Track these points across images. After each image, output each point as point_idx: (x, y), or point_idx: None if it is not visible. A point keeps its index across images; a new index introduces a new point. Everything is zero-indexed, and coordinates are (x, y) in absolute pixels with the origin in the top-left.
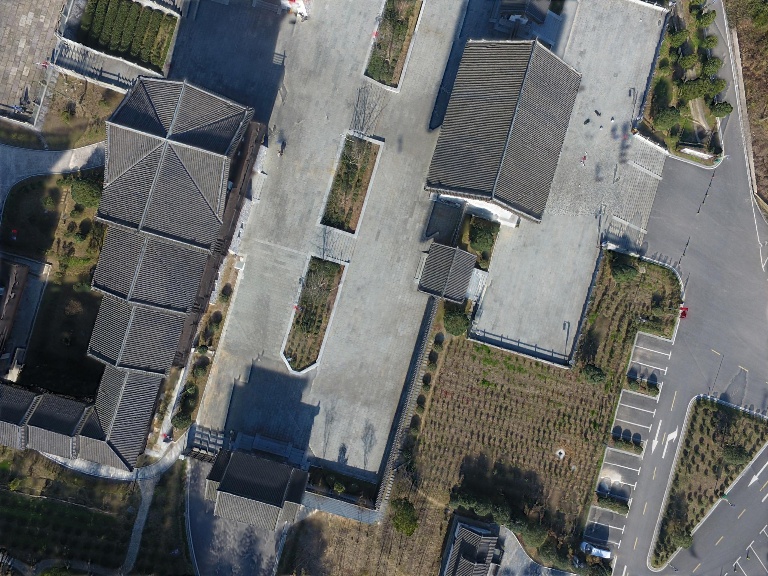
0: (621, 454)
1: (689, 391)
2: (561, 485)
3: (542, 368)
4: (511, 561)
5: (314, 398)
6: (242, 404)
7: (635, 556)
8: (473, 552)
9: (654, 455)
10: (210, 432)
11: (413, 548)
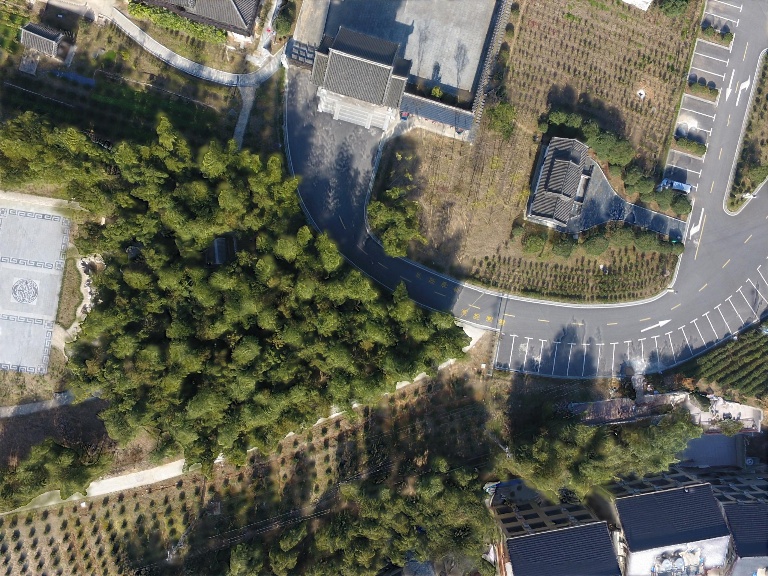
0: (697, 101)
1: (760, 43)
2: (642, 124)
3: (623, 7)
4: (596, 192)
5: (408, 18)
6: (338, 21)
7: (712, 199)
8: (566, 156)
9: (728, 103)
10: (307, 47)
11: (504, 170)
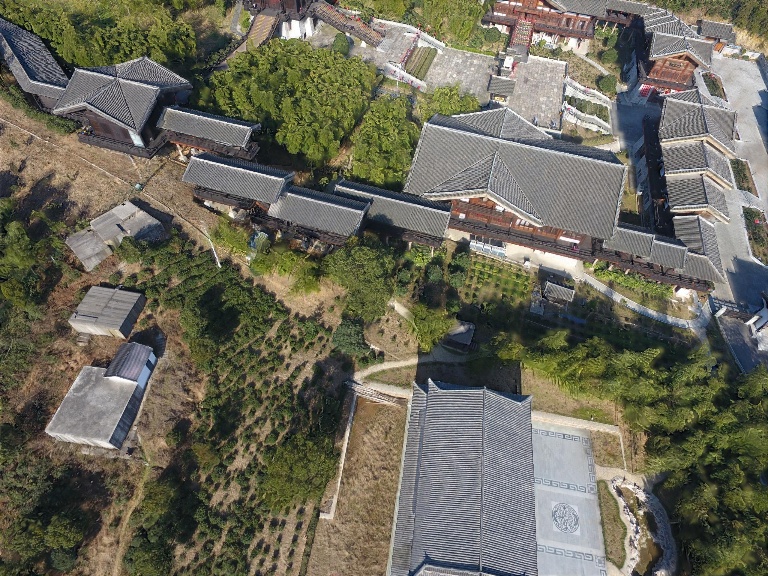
0: None
1: None
2: None
3: None
4: None
5: None
6: (739, 286)
7: None
8: None
9: None
10: (725, 303)
11: None
